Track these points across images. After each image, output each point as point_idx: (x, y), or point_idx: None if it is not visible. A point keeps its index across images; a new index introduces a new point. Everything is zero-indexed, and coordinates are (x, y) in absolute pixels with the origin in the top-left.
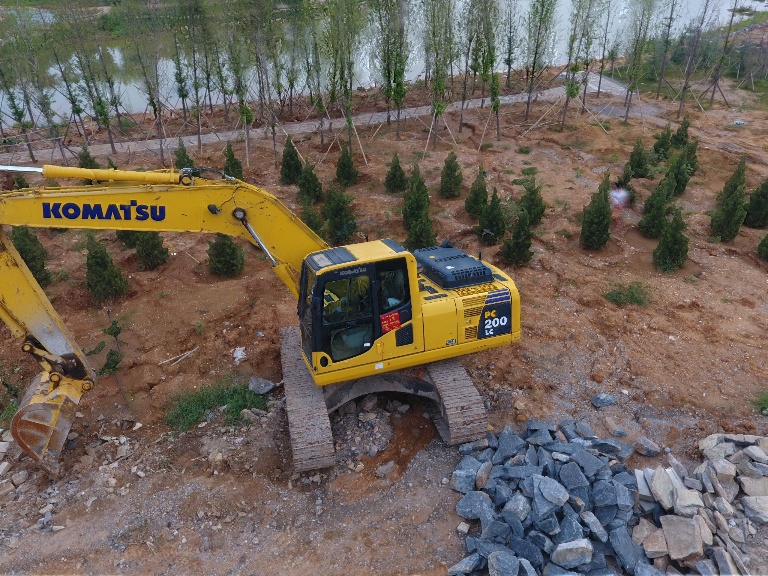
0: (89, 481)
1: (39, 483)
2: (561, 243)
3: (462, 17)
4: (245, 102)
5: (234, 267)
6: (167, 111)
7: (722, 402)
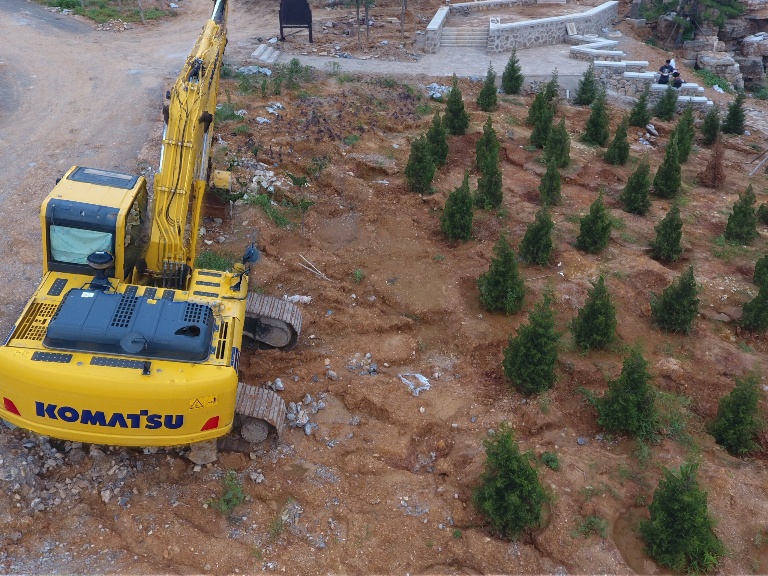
0: None
1: None
2: None
3: None
4: None
5: None
6: None
7: None
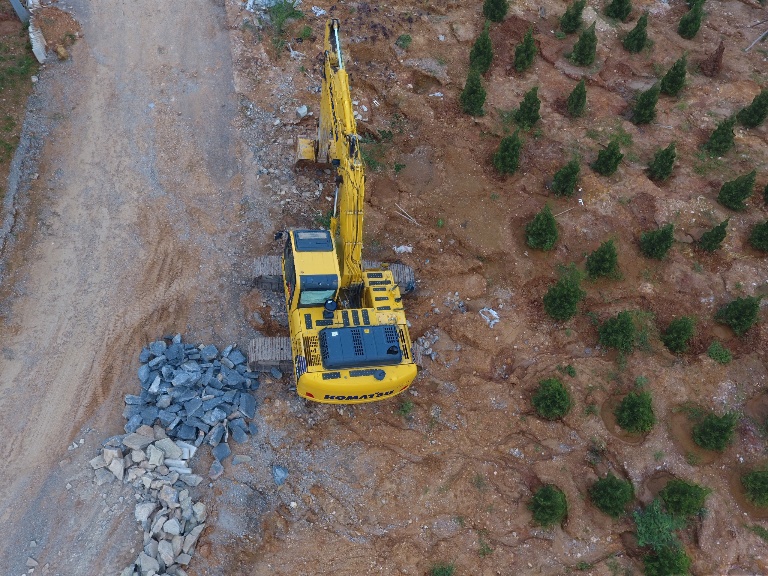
0: None
1: None
2: None
3: None
4: None
5: None
6: None
7: (258, 575)
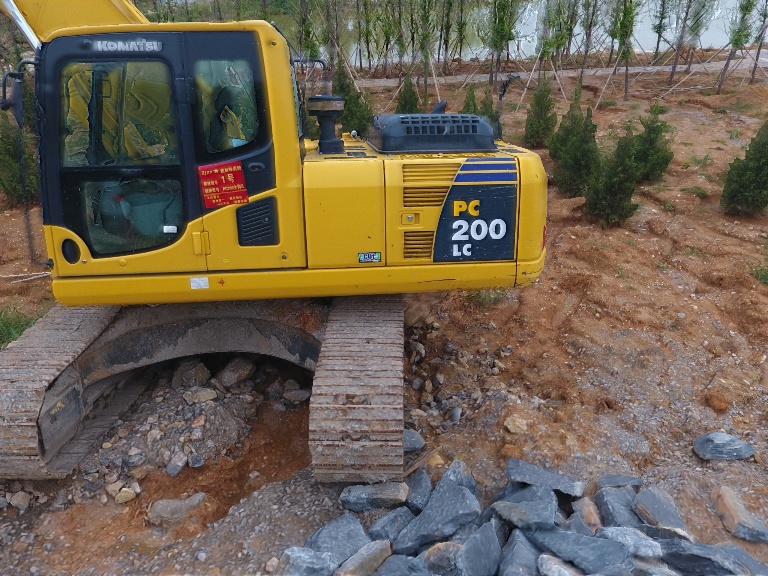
0: None
1: None
2: (688, 202)
3: None
4: (312, 35)
5: None
6: None
7: None
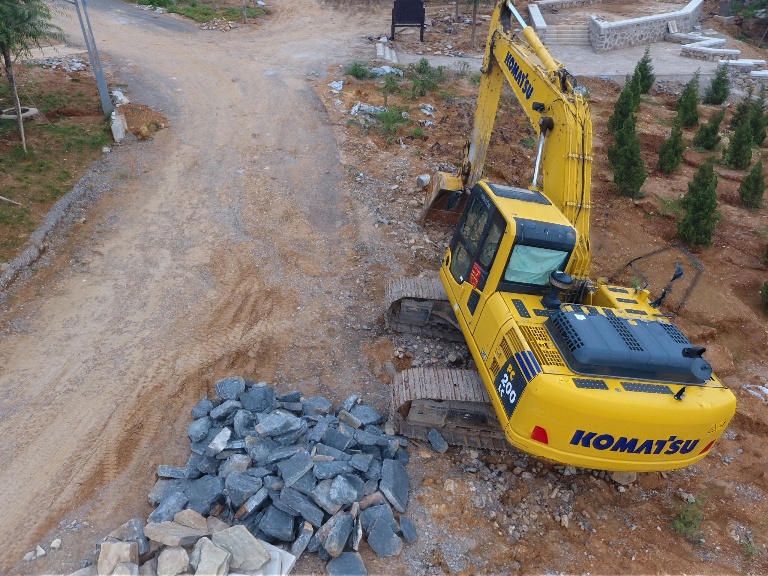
0: None
1: None
2: None
3: None
4: None
5: None
6: None
7: None
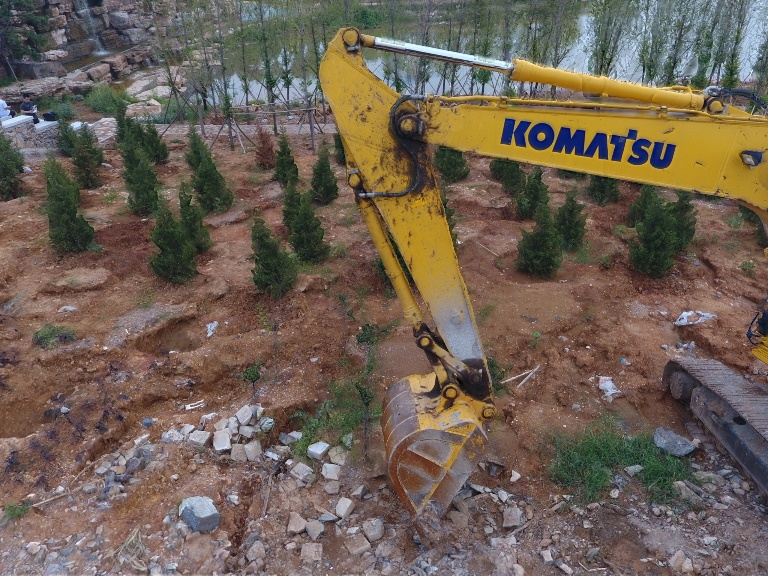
0: (482, 561)
1: (403, 545)
2: None
3: (752, 8)
4: (511, 83)
5: (550, 266)
6: (408, 93)
7: None
